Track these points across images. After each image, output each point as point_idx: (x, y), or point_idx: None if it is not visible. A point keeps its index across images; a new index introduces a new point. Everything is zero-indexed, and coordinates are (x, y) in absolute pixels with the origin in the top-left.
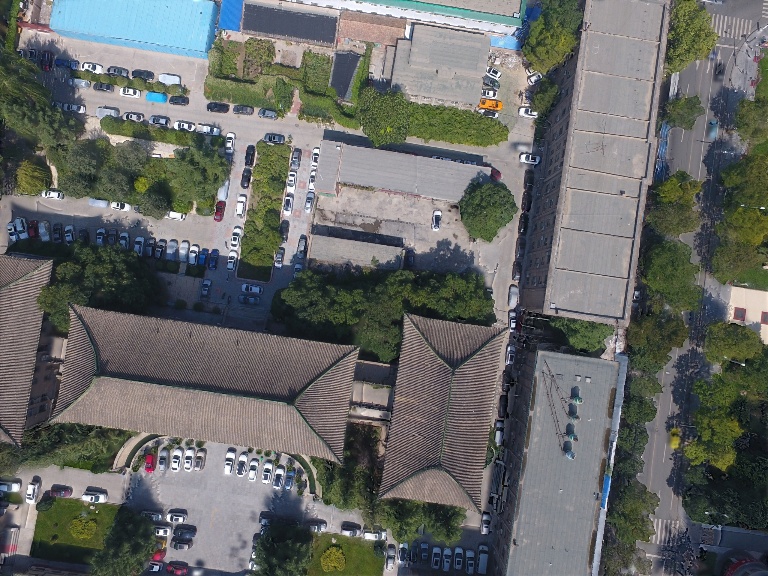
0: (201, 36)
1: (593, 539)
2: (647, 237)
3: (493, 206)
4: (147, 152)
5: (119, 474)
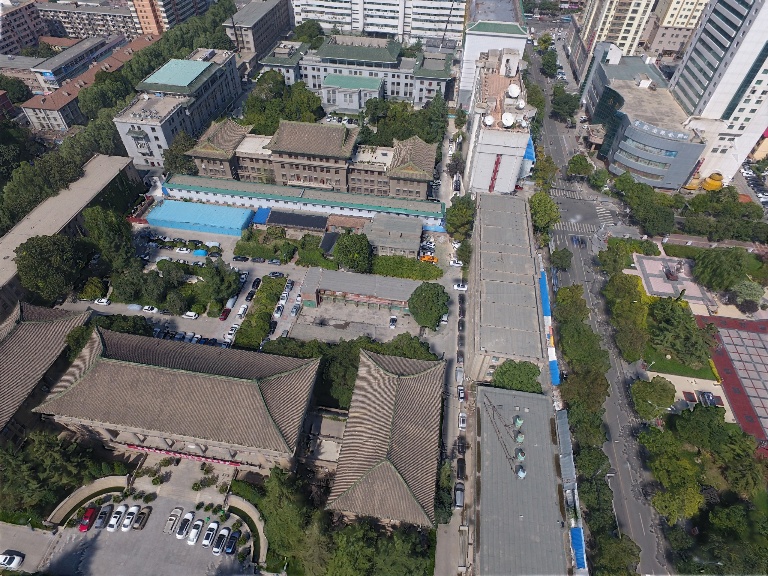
0: (240, 222)
1: None
2: (558, 327)
3: None
4: (183, 280)
5: (48, 535)
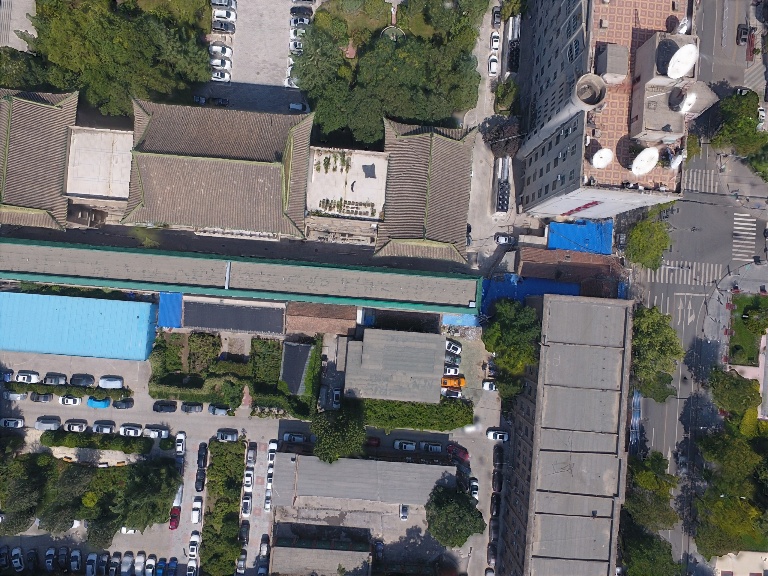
0: (140, 343)
1: None
2: (625, 521)
3: (459, 533)
4: (93, 461)
5: None
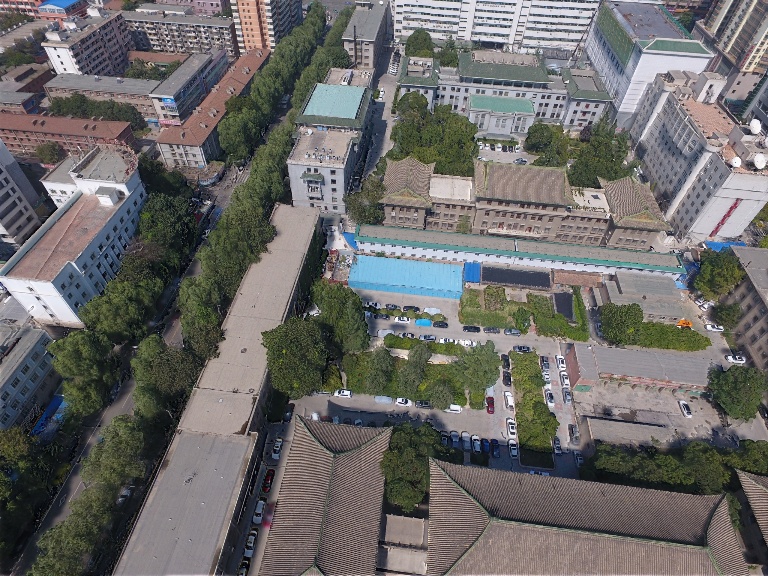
0: (457, 283)
1: None
2: None
3: None
4: None
5: None
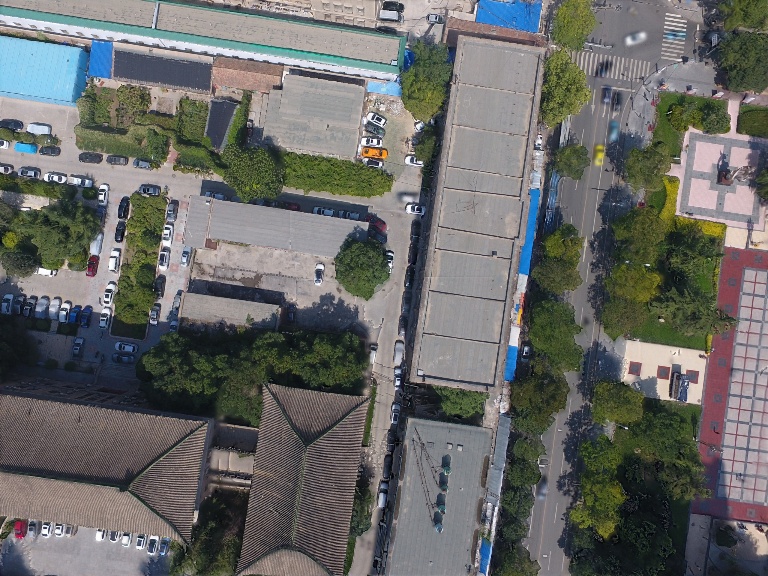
0: (68, 85)
1: None
2: (533, 292)
3: (361, 267)
4: (16, 205)
5: None
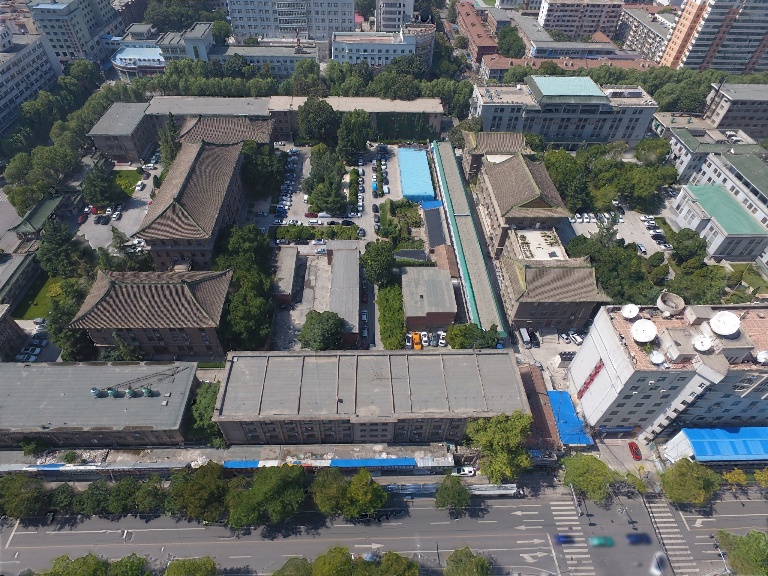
0: (412, 193)
1: (3, 430)
2: None
3: None
4: None
5: None
